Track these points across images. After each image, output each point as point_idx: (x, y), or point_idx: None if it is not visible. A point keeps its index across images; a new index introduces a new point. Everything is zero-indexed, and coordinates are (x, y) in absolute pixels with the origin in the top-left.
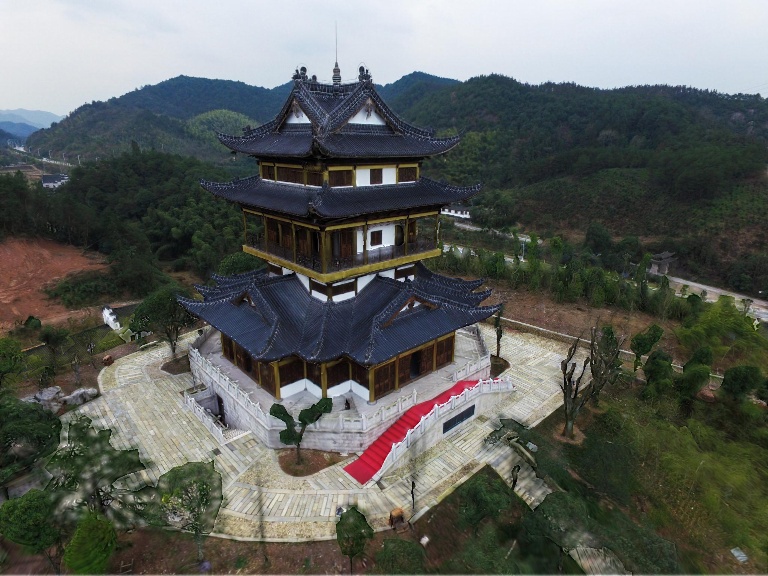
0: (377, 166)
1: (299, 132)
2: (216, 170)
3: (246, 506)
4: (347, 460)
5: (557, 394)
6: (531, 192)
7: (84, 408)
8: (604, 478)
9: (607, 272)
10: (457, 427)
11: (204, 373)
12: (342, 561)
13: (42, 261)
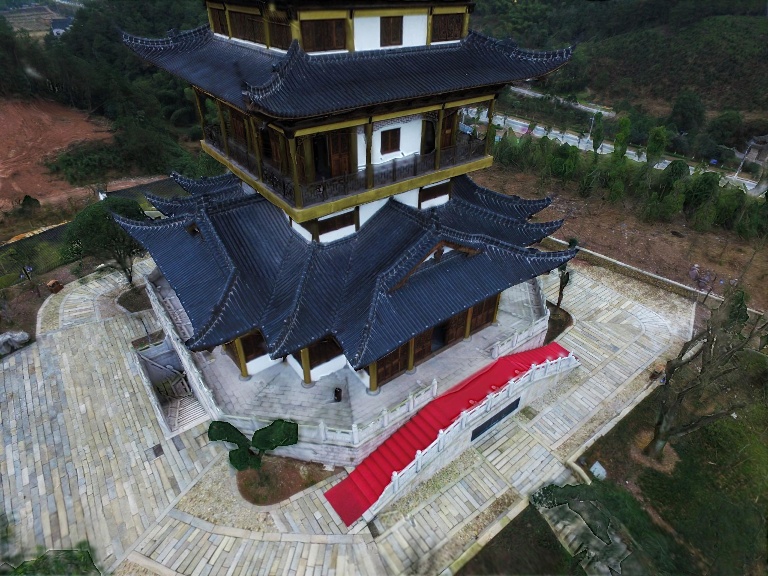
0: (393, 11)
1: None
2: None
3: (179, 557)
4: (331, 479)
5: (638, 375)
6: (610, 47)
7: (10, 361)
8: (716, 564)
9: (691, 157)
10: (492, 428)
11: (160, 319)
12: None
13: (41, 127)
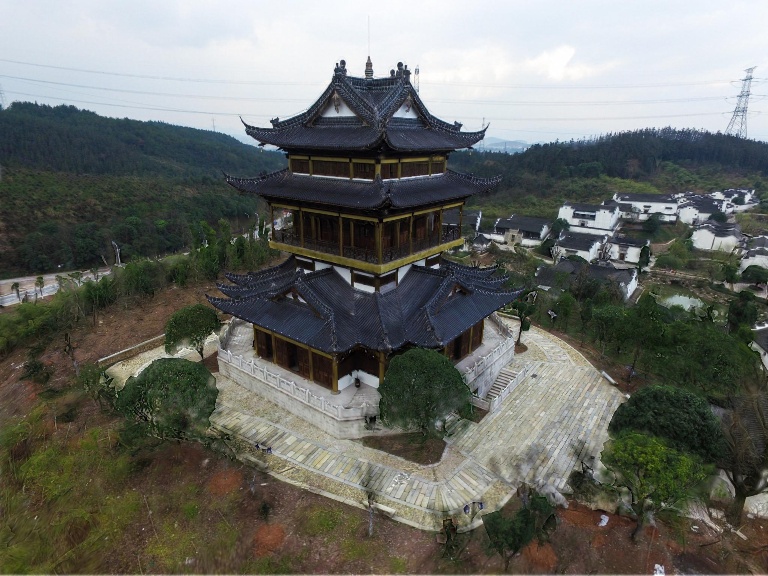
0: None
1: (405, 126)
2: None
3: (562, 355)
4: None
5: None
6: None
7: (552, 483)
8: None
9: None
10: None
11: None
12: (558, 333)
13: None
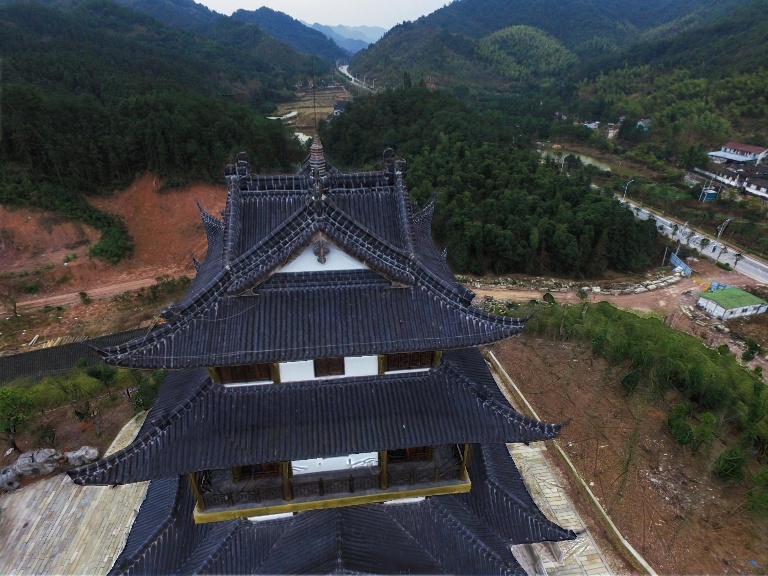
0: None
1: None
2: (463, 113)
3: None
4: None
5: None
6: None
7: None
8: None
9: None
10: None
11: None
12: None
13: None
